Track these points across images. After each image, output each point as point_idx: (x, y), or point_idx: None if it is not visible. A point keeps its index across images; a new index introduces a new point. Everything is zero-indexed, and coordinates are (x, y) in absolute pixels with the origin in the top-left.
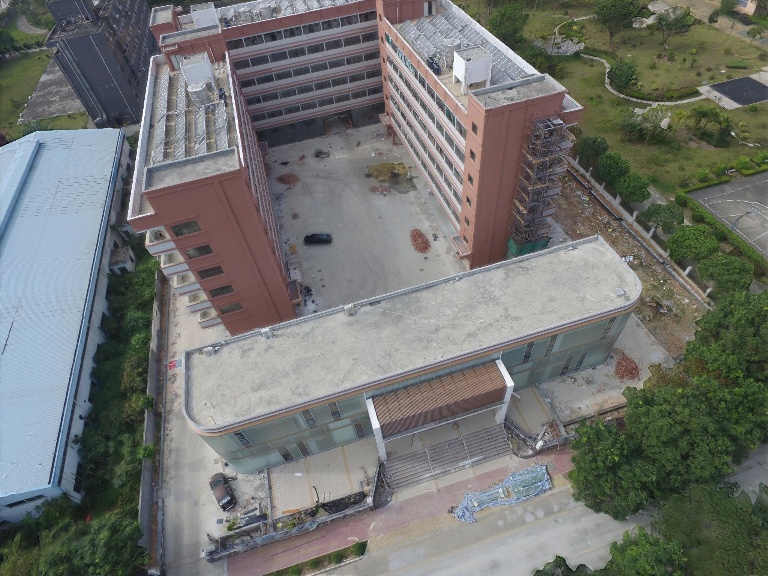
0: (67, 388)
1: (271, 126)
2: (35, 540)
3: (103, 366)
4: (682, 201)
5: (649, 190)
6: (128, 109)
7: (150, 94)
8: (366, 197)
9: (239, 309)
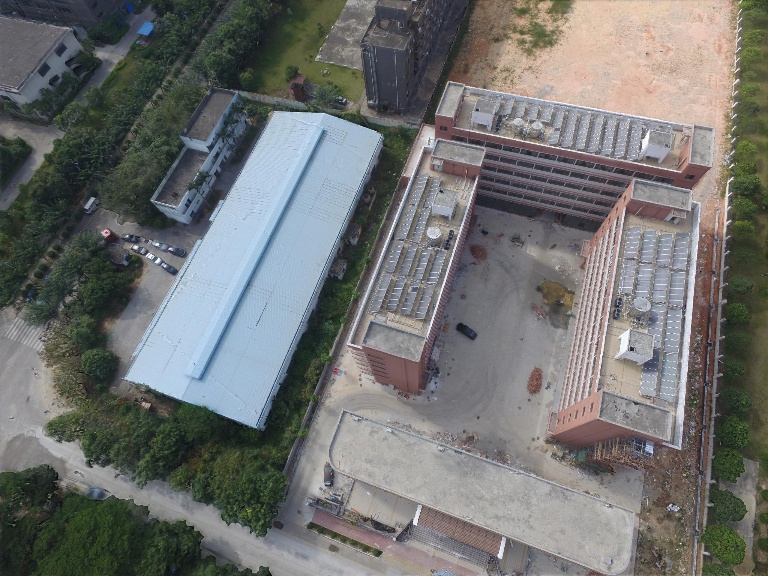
0: (280, 370)
1: (492, 196)
2: (240, 435)
3: (300, 353)
4: (766, 497)
5: (752, 465)
6: (396, 103)
7: (405, 199)
8: (524, 311)
9: (386, 377)
